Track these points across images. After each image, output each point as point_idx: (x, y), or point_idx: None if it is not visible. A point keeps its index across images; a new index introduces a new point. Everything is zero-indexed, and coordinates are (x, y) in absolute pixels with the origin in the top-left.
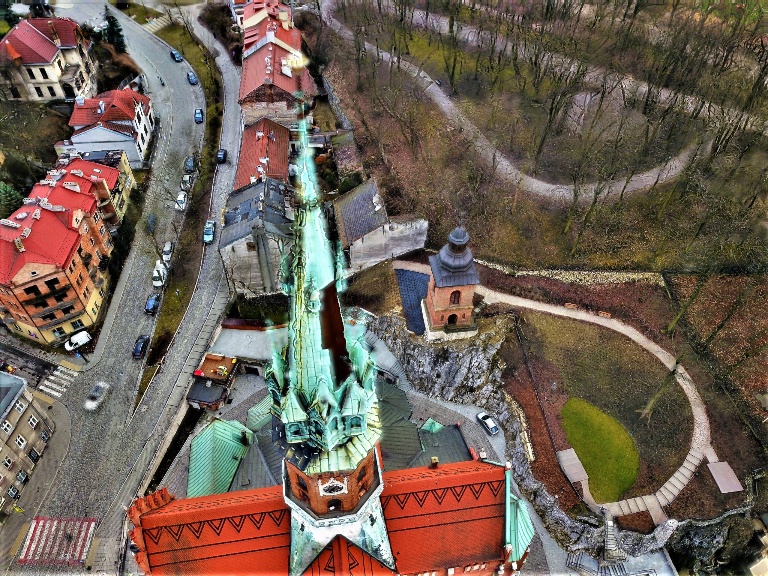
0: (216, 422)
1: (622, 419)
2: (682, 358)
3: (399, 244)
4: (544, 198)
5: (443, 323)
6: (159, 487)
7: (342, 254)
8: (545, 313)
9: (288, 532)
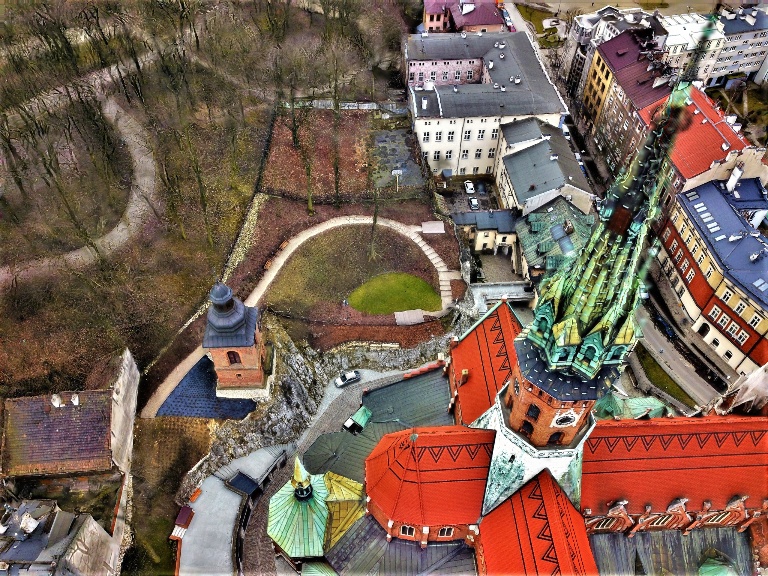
0: None
1: (373, 273)
2: (336, 213)
3: (129, 397)
4: (132, 240)
5: (262, 372)
6: None
7: (86, 488)
8: (270, 286)
9: (560, 489)
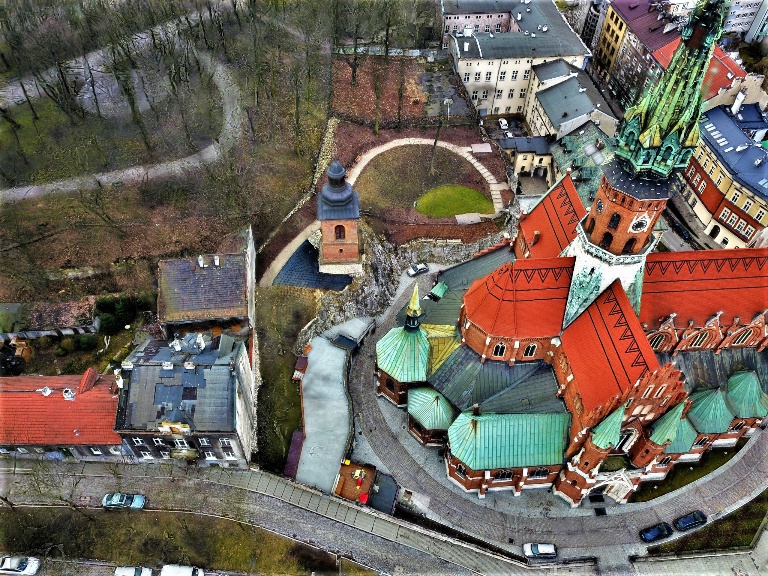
0: (478, 420)
1: (433, 185)
2: (398, 136)
3: (252, 267)
4: (233, 149)
5: None
6: (488, 541)
7: None
8: (352, 189)
9: None
